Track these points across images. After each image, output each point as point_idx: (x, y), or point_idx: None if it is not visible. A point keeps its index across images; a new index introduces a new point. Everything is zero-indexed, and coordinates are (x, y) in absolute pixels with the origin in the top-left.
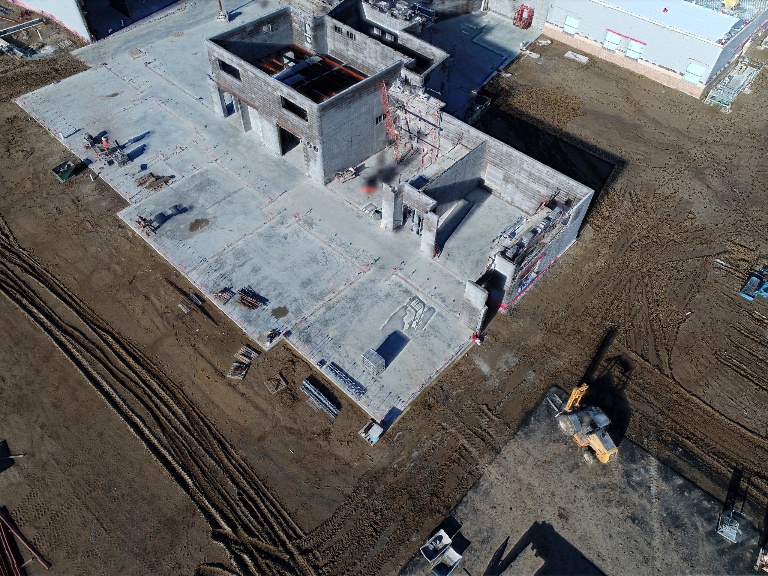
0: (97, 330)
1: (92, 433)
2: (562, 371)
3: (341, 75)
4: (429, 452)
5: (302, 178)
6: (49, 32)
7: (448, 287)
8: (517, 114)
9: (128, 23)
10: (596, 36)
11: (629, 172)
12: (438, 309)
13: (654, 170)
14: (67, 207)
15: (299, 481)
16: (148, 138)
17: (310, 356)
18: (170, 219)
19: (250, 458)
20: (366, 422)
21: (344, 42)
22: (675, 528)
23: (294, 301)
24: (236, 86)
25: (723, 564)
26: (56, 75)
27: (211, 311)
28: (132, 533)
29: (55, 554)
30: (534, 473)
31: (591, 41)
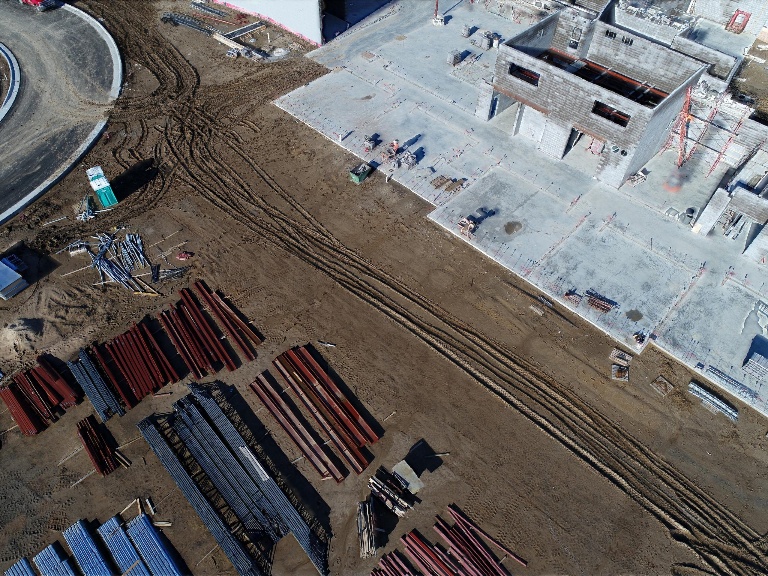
0: (461, 331)
1: (505, 433)
2: None
3: (614, 80)
4: None
5: (591, 182)
6: (273, 35)
7: None
8: None
9: None
10: None
11: None
12: None
13: None
14: (374, 209)
15: (730, 483)
16: (422, 141)
17: (685, 359)
18: (483, 222)
19: (671, 459)
20: None
21: (614, 47)
22: None
23: (643, 304)
24: (526, 90)
25: None
26: (301, 78)
27: (564, 313)
28: (591, 532)
29: (526, 551)
30: None
31: None
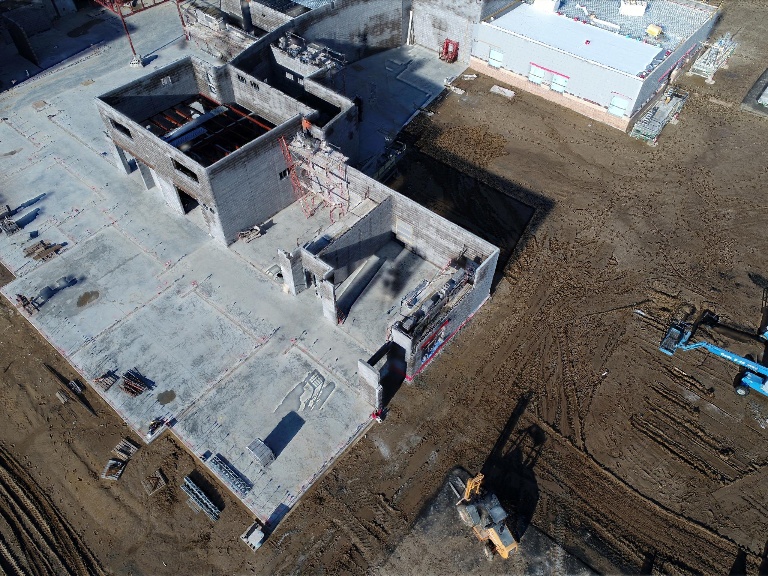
0: None
1: None
2: (467, 449)
3: (246, 126)
4: (317, 555)
5: (204, 239)
6: None
7: (351, 358)
8: (437, 156)
9: (36, 72)
10: (520, 70)
11: (550, 216)
12: (338, 384)
13: (576, 212)
14: None
15: None
16: (43, 201)
17: (194, 448)
18: (57, 293)
19: (117, 575)
20: (250, 523)
21: (249, 91)
22: None
23: (183, 383)
24: (130, 145)
25: None
26: None
27: (91, 399)
28: None
29: None
30: (430, 574)
31: (516, 75)
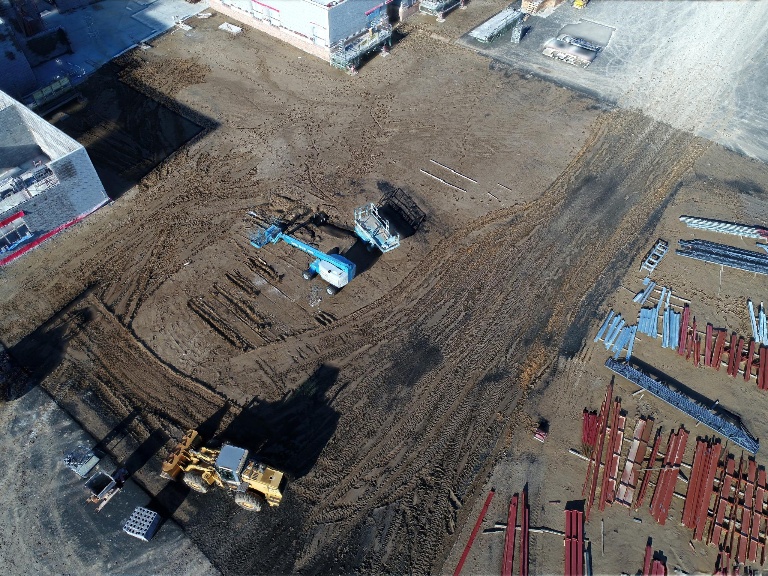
0: None
1: None
2: (15, 326)
3: None
4: None
5: None
6: None
7: None
8: (134, 84)
9: None
10: (245, 6)
11: (215, 134)
12: None
13: (243, 131)
14: None
15: None
16: None
17: None
18: None
19: None
20: None
21: None
22: (32, 469)
23: None
24: None
25: (58, 499)
26: None
27: None
28: None
29: None
30: None
31: (243, 12)
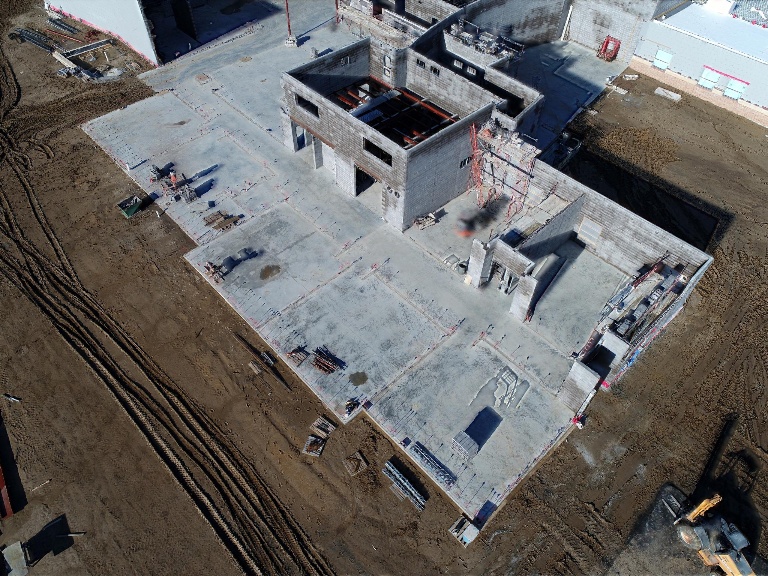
0: (162, 389)
1: (157, 512)
2: (677, 466)
3: (421, 112)
4: (530, 559)
5: (378, 223)
6: (116, 54)
7: (542, 357)
8: (606, 157)
9: (195, 46)
10: (691, 72)
11: (735, 228)
12: (532, 383)
13: (763, 226)
14: (132, 246)
15: None
16: (216, 172)
17: (393, 433)
18: (239, 264)
19: (329, 554)
20: (457, 517)
21: (426, 77)
22: None
23: (373, 366)
24: (312, 122)
25: None
26: (122, 100)
27: (284, 373)
28: None
29: None
30: None
31: (684, 77)
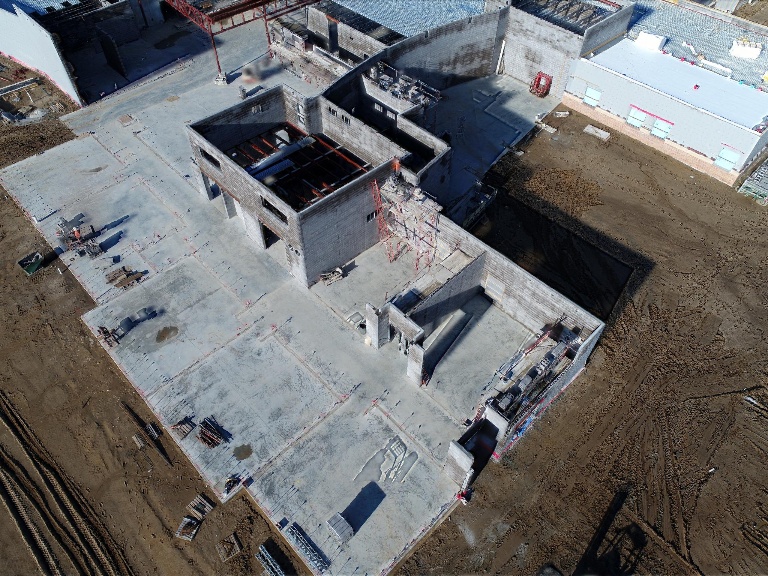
0: (40, 466)
1: None
2: (559, 545)
3: (334, 161)
4: None
5: (285, 278)
6: (41, 93)
7: (434, 425)
8: (527, 201)
9: (123, 84)
10: (619, 111)
11: (649, 278)
12: (421, 455)
13: (678, 276)
14: (30, 306)
15: None
16: (126, 223)
17: (270, 513)
18: (136, 326)
19: None
20: None
21: (339, 125)
22: None
23: (260, 438)
24: (218, 175)
25: None
26: (41, 144)
27: (167, 446)
28: None
29: None
30: None
31: (613, 115)
